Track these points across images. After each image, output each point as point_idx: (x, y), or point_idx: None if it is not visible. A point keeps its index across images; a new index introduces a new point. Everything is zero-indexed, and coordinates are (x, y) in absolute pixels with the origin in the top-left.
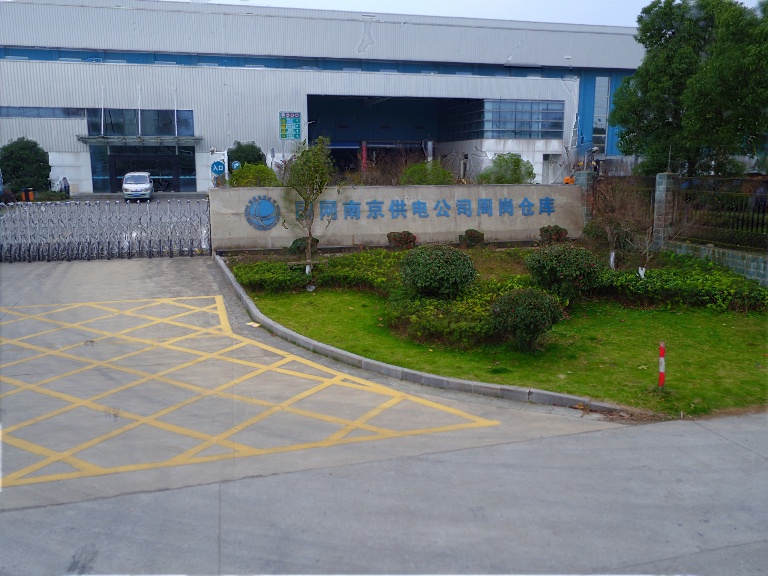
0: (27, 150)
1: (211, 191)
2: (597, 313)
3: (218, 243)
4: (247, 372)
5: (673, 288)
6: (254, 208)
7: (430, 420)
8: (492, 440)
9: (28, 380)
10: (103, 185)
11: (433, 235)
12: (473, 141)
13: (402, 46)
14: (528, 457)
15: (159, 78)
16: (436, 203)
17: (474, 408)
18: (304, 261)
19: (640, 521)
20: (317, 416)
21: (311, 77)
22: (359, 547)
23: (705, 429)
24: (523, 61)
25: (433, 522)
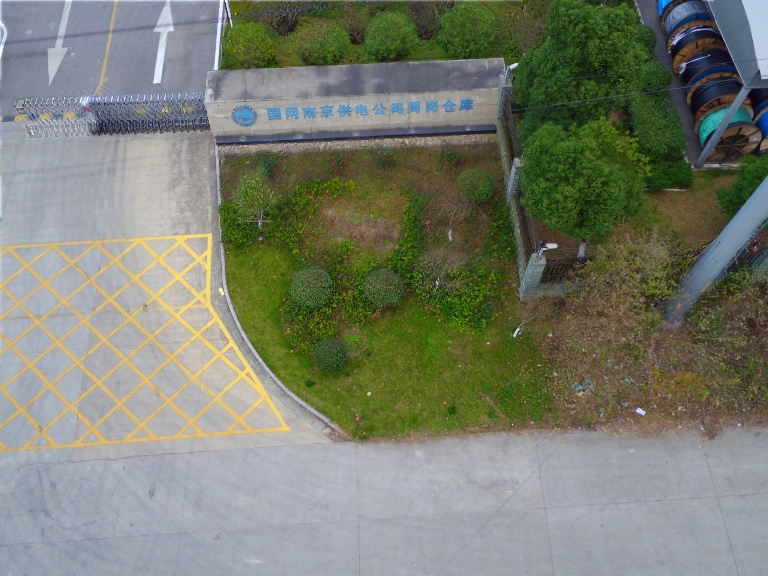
0: None
1: (206, 104)
2: (397, 311)
3: (216, 134)
4: (210, 358)
5: None
6: (238, 113)
7: (267, 422)
8: (281, 443)
9: (124, 352)
10: None
11: (372, 126)
12: None
13: None
14: (286, 458)
15: None
16: None
17: (286, 416)
18: None
19: (295, 505)
20: (228, 410)
21: None
22: (219, 500)
23: (356, 452)
24: None
25: (241, 492)
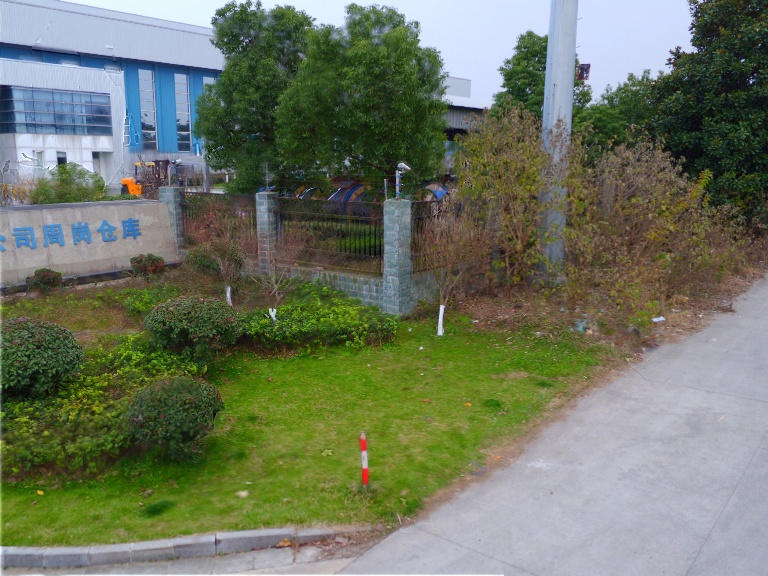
0: None
1: None
2: (238, 373)
3: None
4: None
5: (311, 330)
6: None
7: None
8: None
9: None
10: None
11: None
12: (2, 135)
13: None
14: None
15: None
16: None
17: None
18: None
19: None
20: None
21: None
22: None
23: (433, 536)
24: (56, 45)
25: None
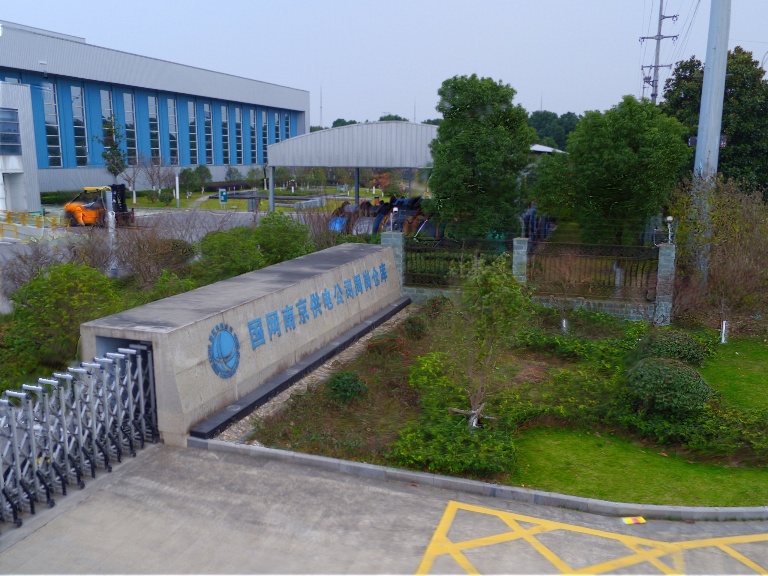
0: None
1: (169, 336)
2: None
3: (191, 419)
4: None
5: None
6: (215, 347)
7: None
8: None
9: None
10: None
11: (339, 327)
12: None
13: None
14: None
15: None
16: (334, 289)
17: None
18: None
19: None
20: None
21: None
22: None
23: None
24: None
25: None
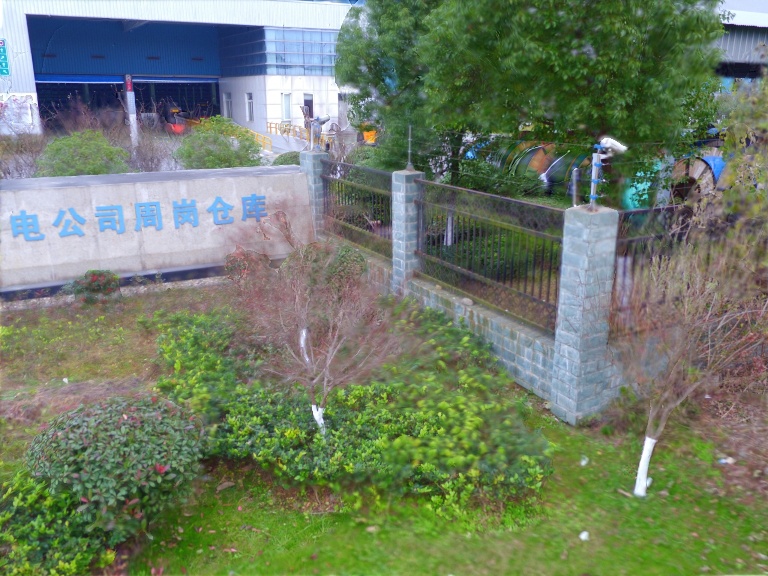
0: None
1: None
2: (197, 551)
3: None
4: None
5: (363, 468)
6: None
7: None
8: None
9: None
10: None
11: (56, 268)
12: (256, 77)
13: None
14: None
15: None
16: (57, 215)
17: None
18: None
19: None
20: None
21: None
22: None
23: None
24: None
25: None
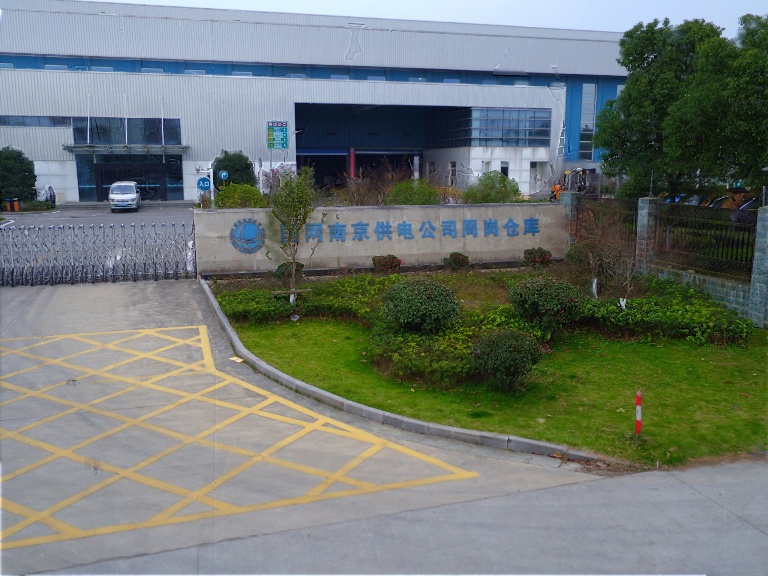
0: (12, 160)
1: (196, 215)
2: (578, 346)
3: (203, 266)
4: (229, 416)
5: (653, 320)
6: (239, 231)
7: (409, 472)
8: (470, 495)
9: (8, 427)
10: (89, 194)
11: (418, 256)
12: (461, 149)
13: (390, 53)
14: (505, 515)
15: (146, 86)
16: (421, 224)
17: (453, 458)
18: (288, 290)
19: None
20: (297, 467)
21: (299, 85)
22: None
23: (680, 481)
24: (510, 69)
25: None
